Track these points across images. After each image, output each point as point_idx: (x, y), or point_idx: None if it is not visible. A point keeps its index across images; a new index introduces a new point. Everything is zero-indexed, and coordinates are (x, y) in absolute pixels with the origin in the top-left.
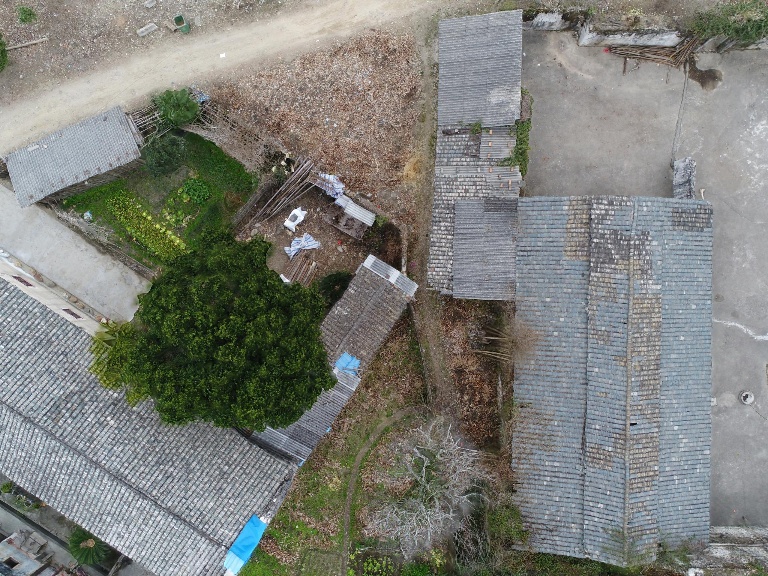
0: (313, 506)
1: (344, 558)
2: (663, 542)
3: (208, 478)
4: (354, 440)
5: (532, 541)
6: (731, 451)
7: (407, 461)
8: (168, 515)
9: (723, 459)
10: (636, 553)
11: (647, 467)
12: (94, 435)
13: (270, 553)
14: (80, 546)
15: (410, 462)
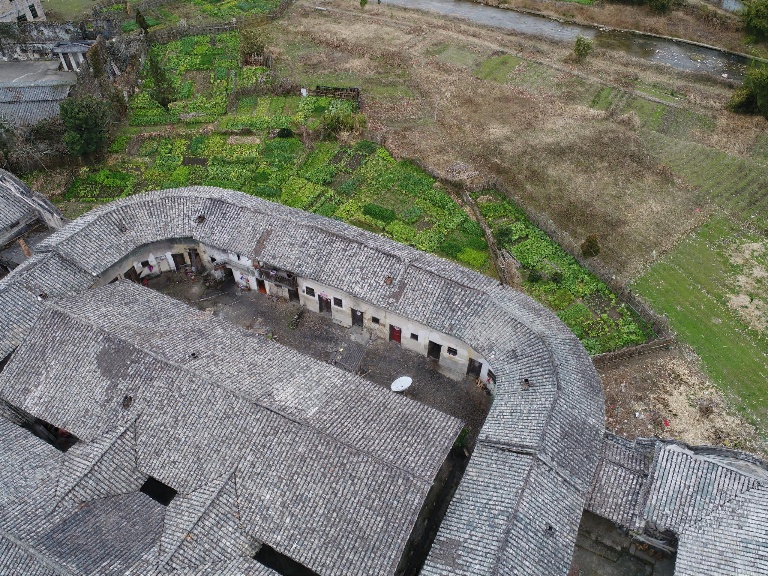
0: None
1: None
2: None
3: None
4: None
5: None
6: None
7: None
8: None
9: None
10: None
11: None
12: None
13: None
14: None
15: None
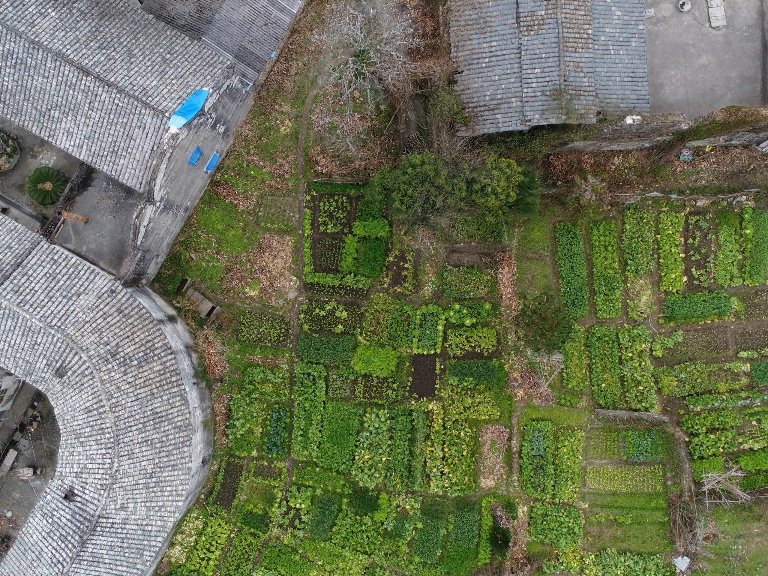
0: (266, 151)
1: (300, 201)
2: (603, 109)
3: (150, 63)
4: (302, 83)
5: (475, 124)
6: (672, 59)
7: (355, 98)
8: (112, 90)
9: (664, 68)
10: (575, 110)
11: (580, 29)
12: (35, 21)
13: (227, 199)
14: (38, 187)
15: (358, 99)
